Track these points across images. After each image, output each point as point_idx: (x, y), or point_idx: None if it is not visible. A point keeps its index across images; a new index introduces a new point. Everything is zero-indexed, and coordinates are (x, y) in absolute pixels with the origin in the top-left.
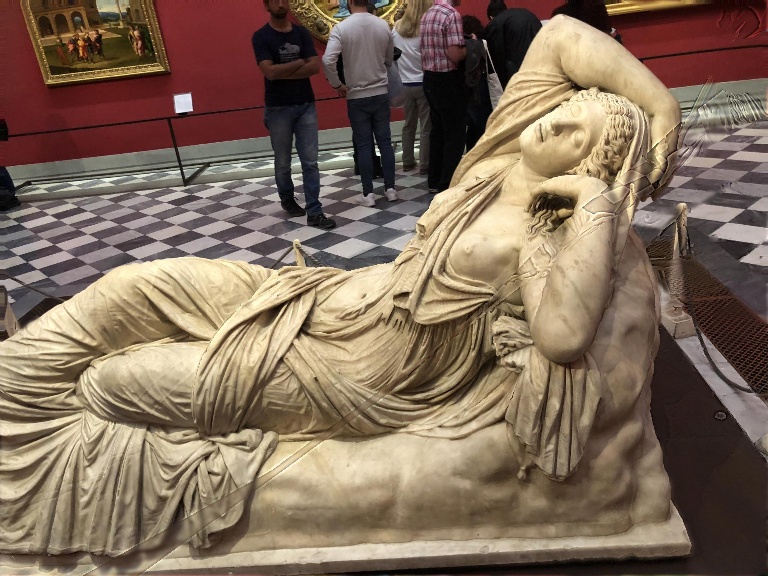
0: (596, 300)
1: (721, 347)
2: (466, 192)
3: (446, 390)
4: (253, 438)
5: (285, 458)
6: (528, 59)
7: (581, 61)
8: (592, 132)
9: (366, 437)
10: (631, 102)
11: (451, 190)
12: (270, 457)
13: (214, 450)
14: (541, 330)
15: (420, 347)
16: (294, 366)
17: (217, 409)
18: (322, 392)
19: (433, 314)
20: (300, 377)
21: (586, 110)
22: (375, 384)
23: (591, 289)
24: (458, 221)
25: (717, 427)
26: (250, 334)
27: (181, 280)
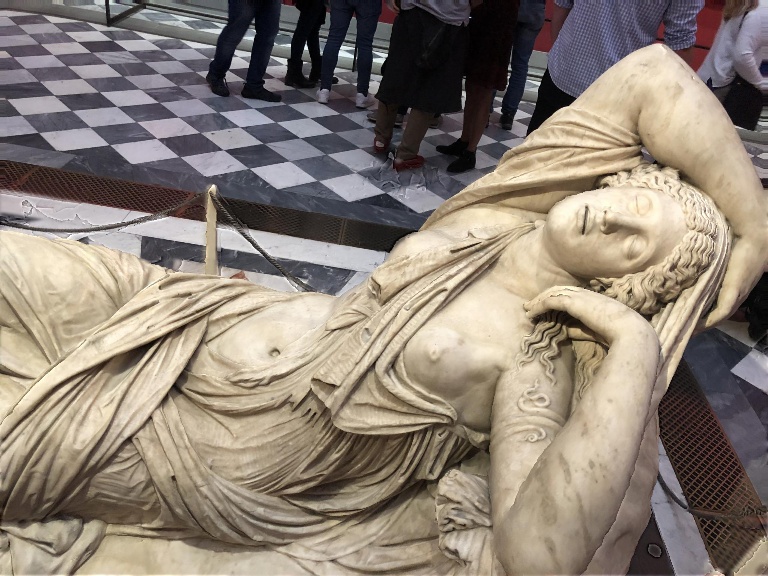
0: (603, 527)
1: (663, 432)
2: (450, 254)
3: (352, 509)
4: (64, 538)
5: (107, 568)
6: (593, 92)
7: (670, 128)
8: (658, 247)
9: (230, 545)
10: (717, 209)
11: (429, 238)
12: (86, 562)
13: (1, 546)
14: (512, 545)
15: (332, 451)
16: (145, 453)
17: (13, 499)
18: (179, 495)
19: (361, 422)
20: (151, 471)
21: (660, 211)
22: (259, 484)
23: (602, 512)
24: (429, 299)
25: (650, 570)
26: (89, 391)
27: (0, 279)
